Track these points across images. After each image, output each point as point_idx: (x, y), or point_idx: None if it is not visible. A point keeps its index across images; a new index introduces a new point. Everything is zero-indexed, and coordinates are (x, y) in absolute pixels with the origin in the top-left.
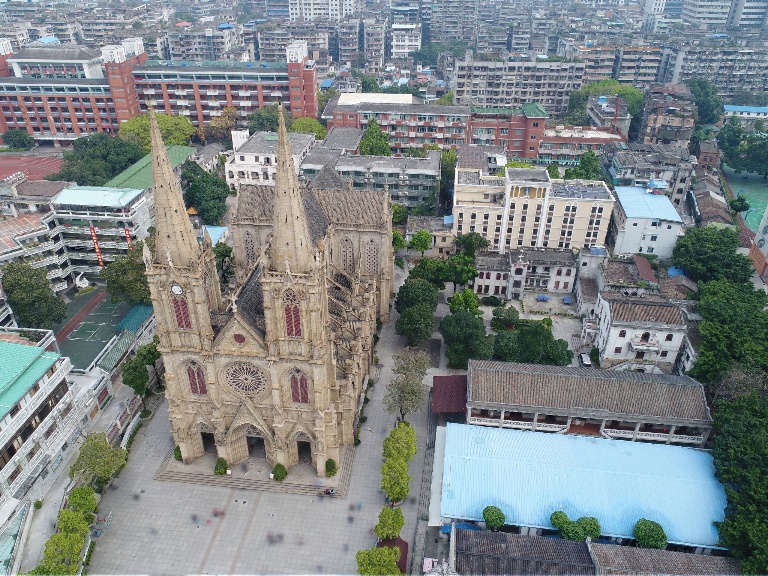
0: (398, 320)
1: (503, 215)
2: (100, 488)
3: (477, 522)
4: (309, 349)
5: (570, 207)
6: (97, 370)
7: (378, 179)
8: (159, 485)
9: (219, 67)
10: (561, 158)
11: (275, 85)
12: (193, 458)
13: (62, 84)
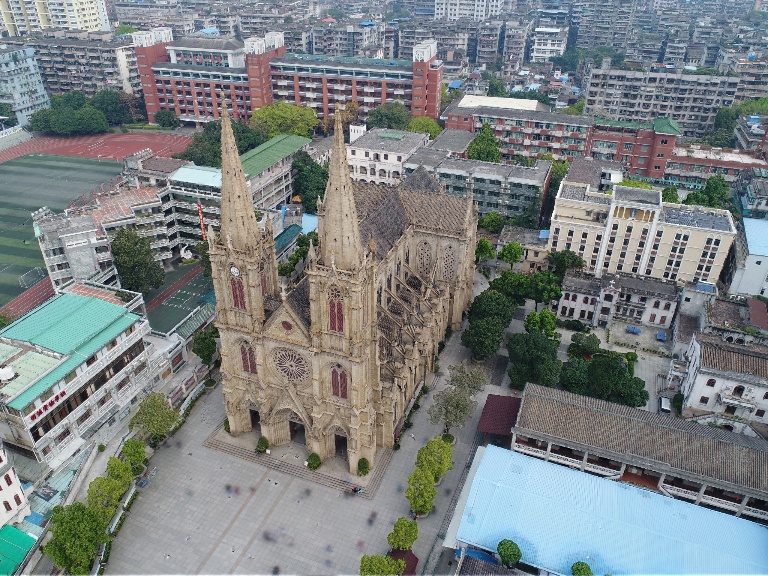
0: (466, 331)
1: (603, 236)
2: (155, 443)
3: (494, 553)
4: (349, 346)
5: (681, 235)
6: (177, 336)
7: (479, 185)
8: (205, 451)
9: (348, 63)
10: (690, 180)
11: (399, 83)
12: (240, 432)
13: (208, 71)
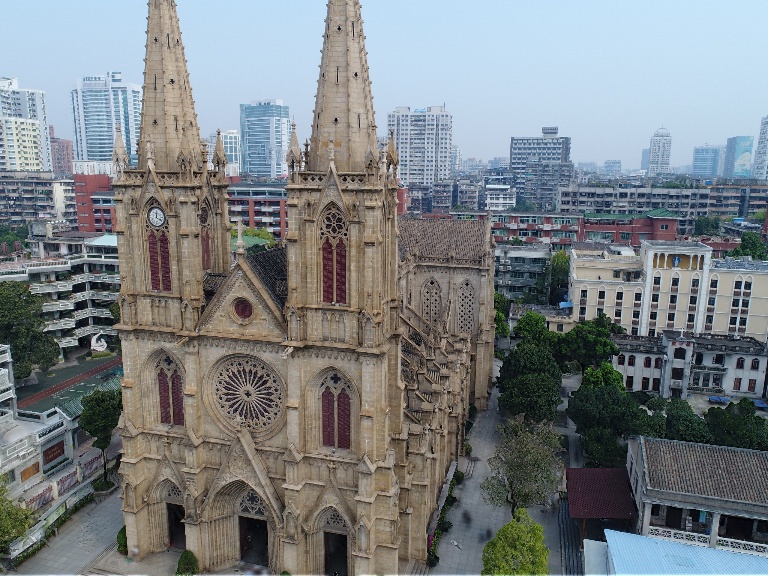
0: (503, 394)
1: (643, 293)
2: None
3: None
4: (358, 328)
5: (741, 283)
6: None
7: None
8: None
9: None
10: None
11: None
12: (147, 553)
13: None
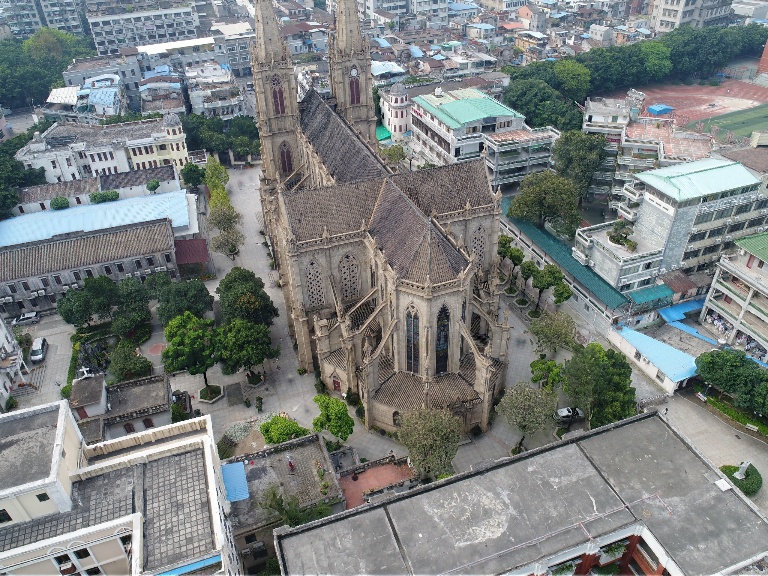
0: None
1: None
2: None
3: None
4: None
5: None
6: None
7: None
8: None
9: None
10: None
11: None
12: None
13: None
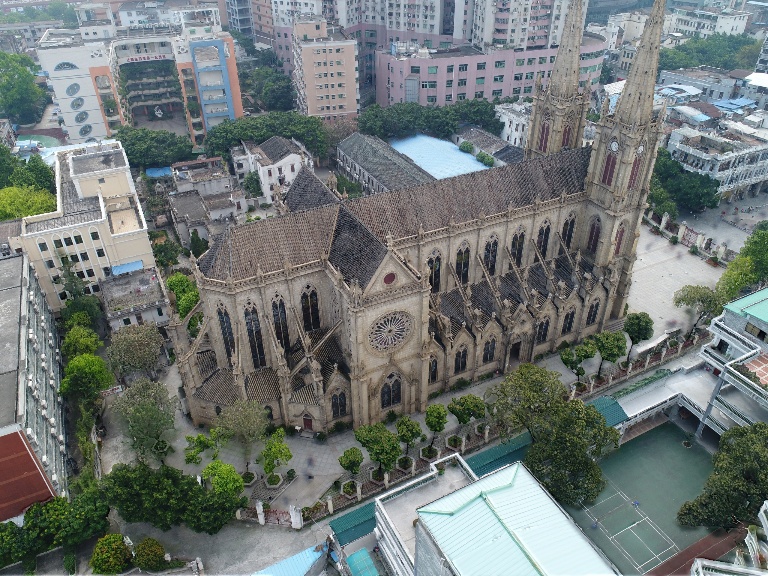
0: None
1: None
2: None
3: None
4: None
5: None
6: None
7: None
8: None
9: None
10: None
11: None
12: None
13: None
